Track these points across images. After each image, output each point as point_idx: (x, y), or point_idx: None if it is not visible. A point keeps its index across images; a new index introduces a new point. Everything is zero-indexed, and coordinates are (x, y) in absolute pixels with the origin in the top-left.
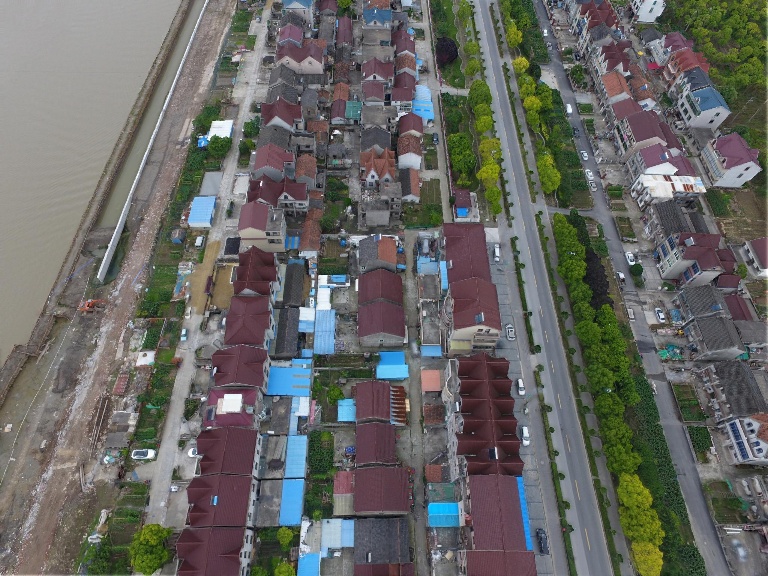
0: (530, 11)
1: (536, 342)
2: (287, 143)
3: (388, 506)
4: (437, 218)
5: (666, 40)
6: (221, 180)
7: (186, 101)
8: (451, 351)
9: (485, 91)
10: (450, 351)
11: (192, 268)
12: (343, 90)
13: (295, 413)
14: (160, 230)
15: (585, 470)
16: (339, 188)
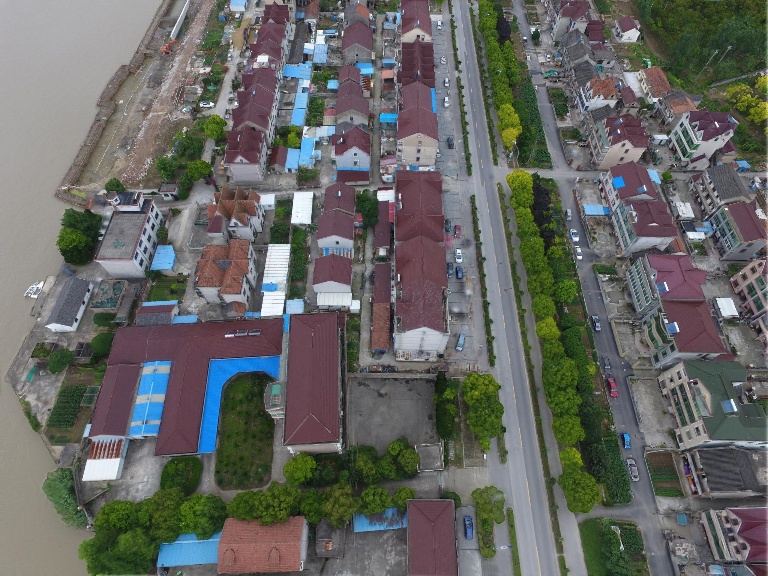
0: None
1: (460, 65)
2: None
3: (355, 109)
4: None
5: None
6: None
7: None
8: None
9: None
10: None
11: (233, 30)
12: None
13: (301, 85)
14: (210, 16)
15: (483, 118)
16: None
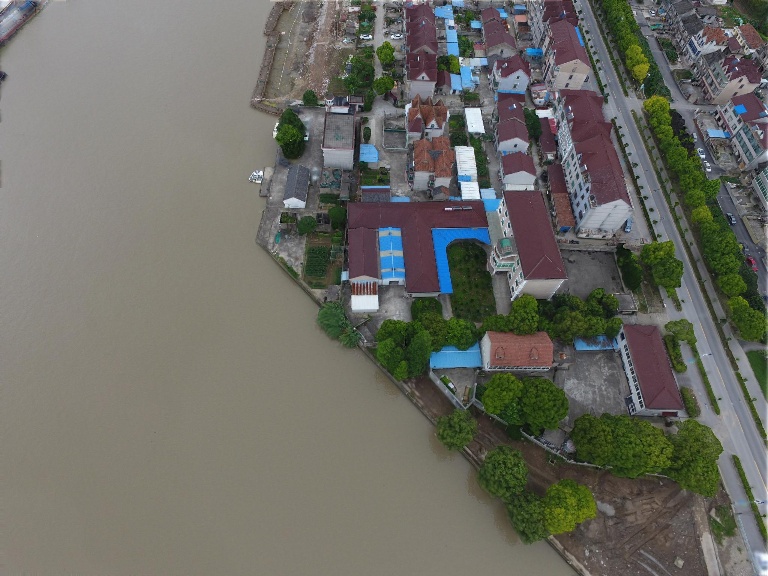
0: None
1: (579, 16)
2: None
3: (507, 42)
4: None
5: None
6: None
7: None
8: None
9: None
10: None
11: None
12: None
13: (447, 24)
14: None
15: (607, 59)
16: None
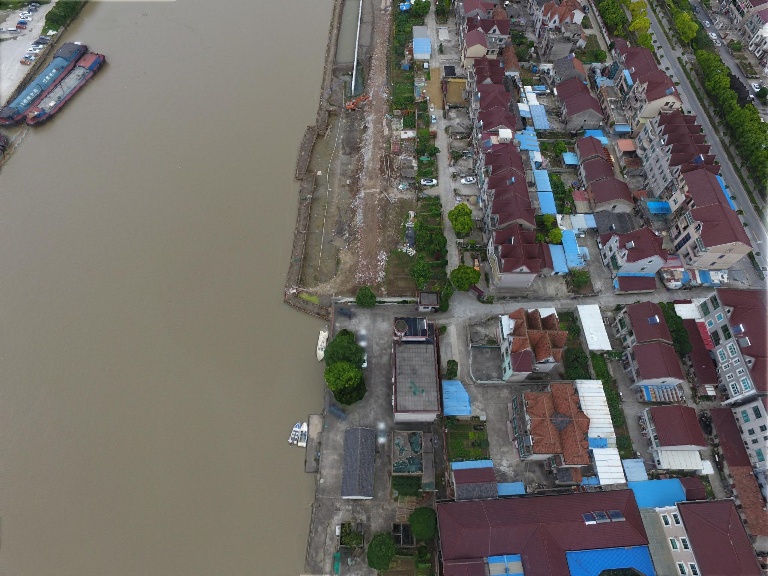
0: None
1: None
2: None
3: (623, 197)
4: (605, 54)
5: None
6: (427, 31)
7: None
8: (639, 127)
9: None
10: (638, 127)
11: (424, 83)
12: None
13: (533, 159)
14: (387, 63)
15: (746, 201)
16: (520, 37)
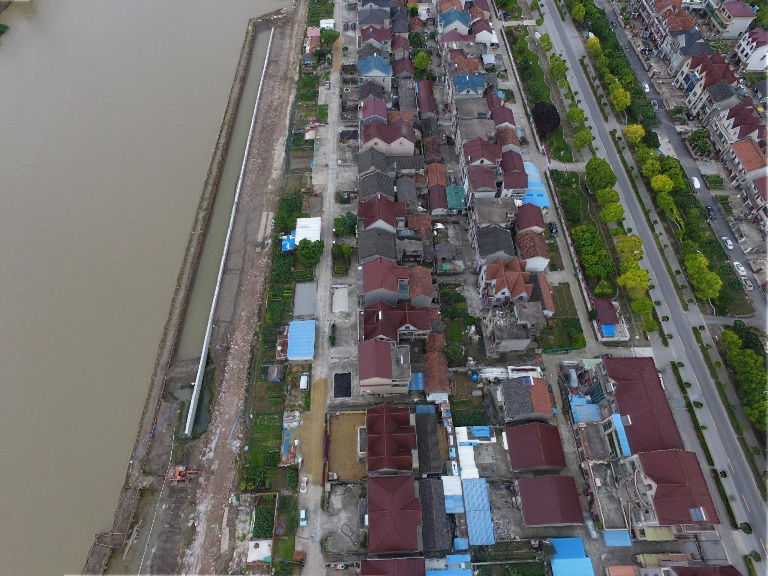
0: (624, 62)
1: (735, 511)
2: (393, 250)
3: None
4: (583, 341)
5: None
6: (316, 294)
7: (259, 189)
8: None
9: (610, 173)
10: None
11: (299, 418)
12: (439, 172)
13: None
14: (251, 362)
15: None
16: (456, 301)
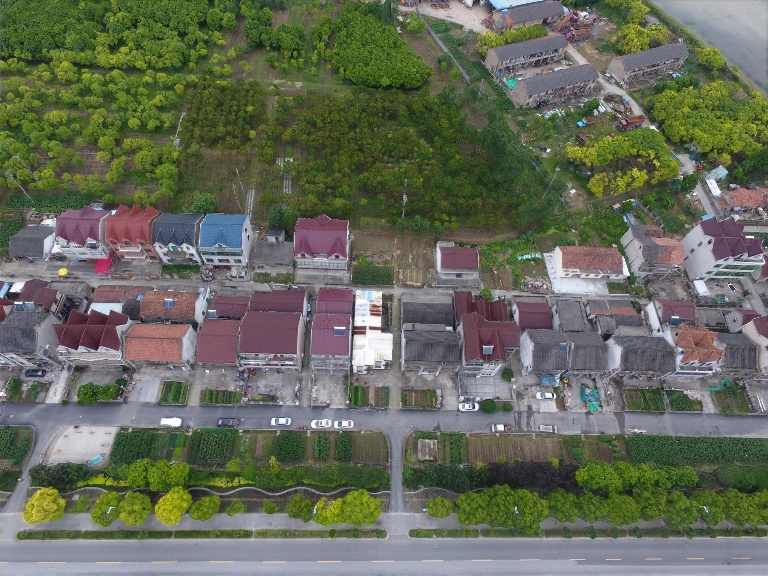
0: None
1: None
2: None
3: None
4: None
5: (71, 240)
6: None
7: None
8: None
9: None
10: None
11: None
12: None
13: None
14: None
15: (763, 543)
16: None
